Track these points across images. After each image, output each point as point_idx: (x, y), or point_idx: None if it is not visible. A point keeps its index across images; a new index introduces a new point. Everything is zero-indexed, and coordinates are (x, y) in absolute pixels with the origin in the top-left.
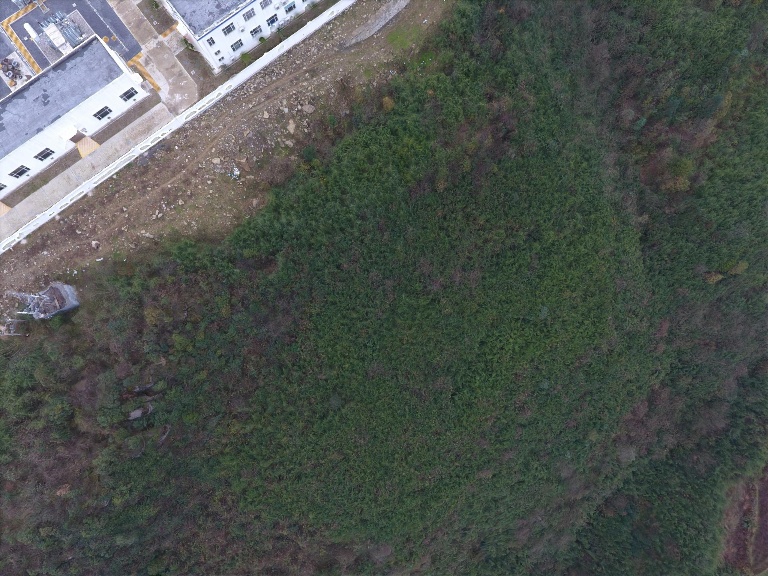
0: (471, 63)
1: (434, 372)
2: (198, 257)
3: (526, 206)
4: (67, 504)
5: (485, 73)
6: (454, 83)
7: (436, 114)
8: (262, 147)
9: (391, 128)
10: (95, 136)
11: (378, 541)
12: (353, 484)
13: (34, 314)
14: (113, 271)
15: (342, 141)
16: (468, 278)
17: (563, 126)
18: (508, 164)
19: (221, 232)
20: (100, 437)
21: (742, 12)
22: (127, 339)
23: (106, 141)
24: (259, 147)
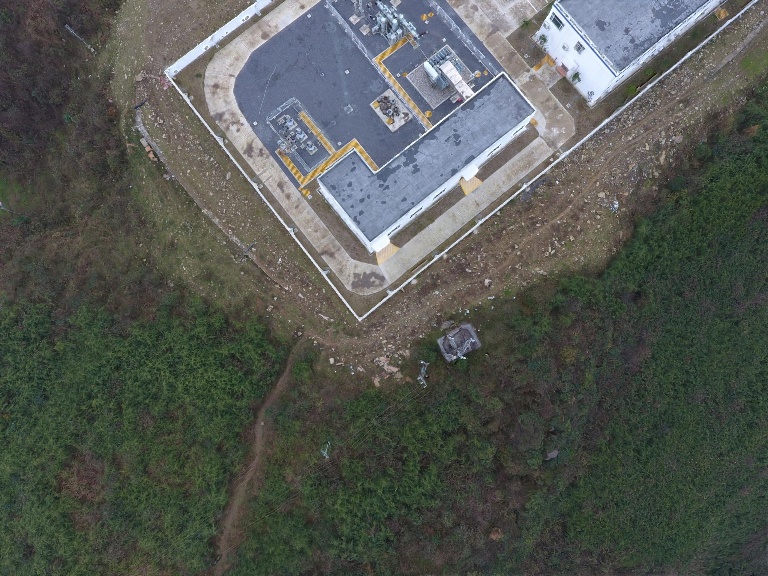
0: None
1: (729, 394)
2: (594, 293)
3: None
4: (497, 548)
5: None
6: None
7: None
8: (637, 179)
9: (756, 156)
10: None
11: (662, 564)
12: (657, 509)
13: (447, 356)
14: (518, 310)
15: (709, 170)
16: (765, 299)
17: None
18: None
19: (598, 266)
20: (524, 479)
21: None
22: (553, 380)
23: (488, 178)
24: (635, 179)
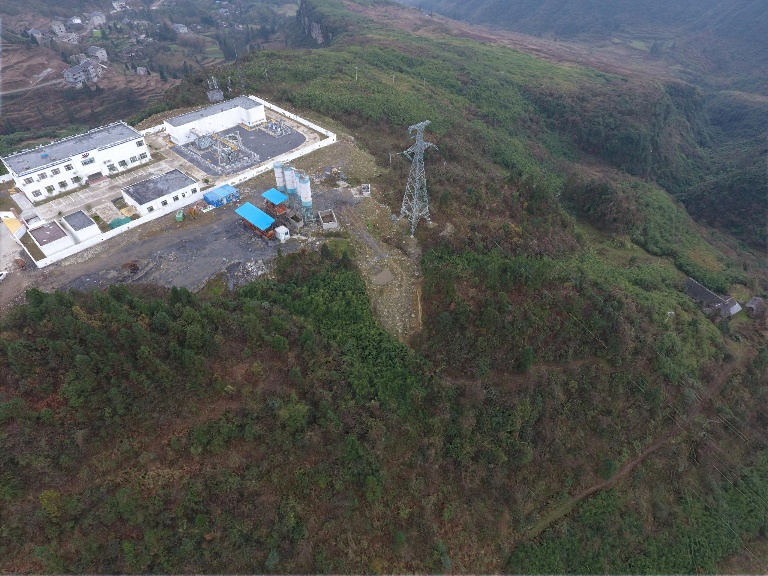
0: None
1: None
2: None
3: None
4: None
5: None
6: None
7: None
8: None
9: None
10: None
11: None
12: None
13: None
14: None
15: None
16: None
17: None
18: None
19: None
20: None
21: None
22: None
23: None
24: None
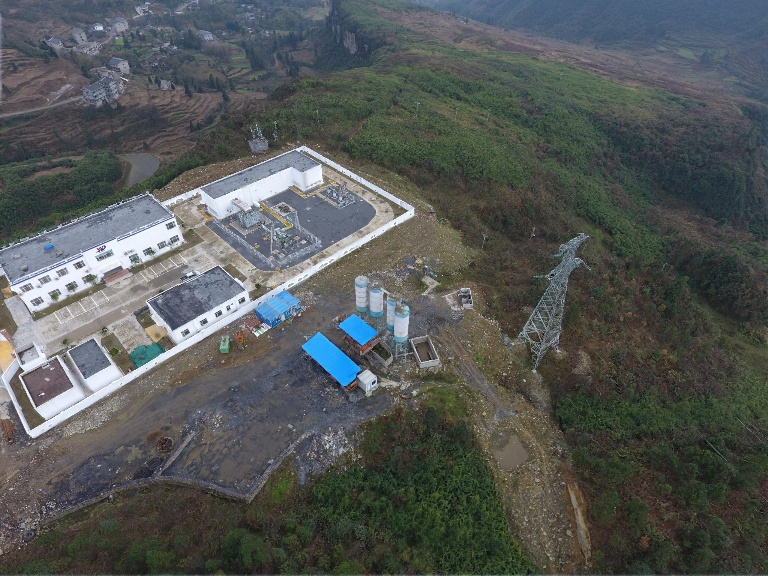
0: None
1: None
2: None
3: None
4: None
5: None
6: None
7: None
8: None
9: None
10: None
11: None
12: None
13: None
14: None
15: None
16: None
17: None
18: None
19: None
20: None
21: None
22: None
23: None
24: None
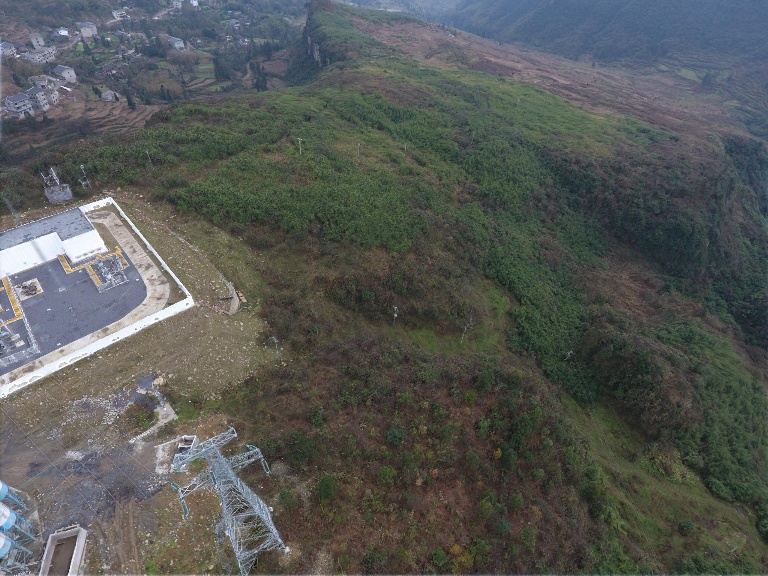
0: None
1: None
2: None
3: None
4: None
5: None
6: None
7: None
8: None
9: None
10: None
11: None
12: None
13: None
14: None
15: None
16: None
17: None
18: None
19: None
20: None
21: None
22: None
23: None
24: None
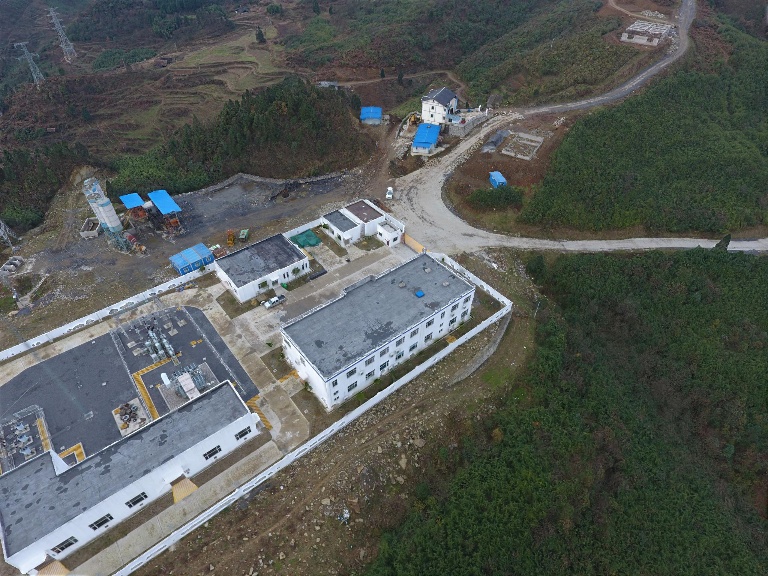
0: (564, 397)
1: None
2: None
3: (656, 549)
4: None
5: (576, 405)
6: (553, 415)
7: (546, 445)
8: (373, 484)
9: (506, 460)
10: (195, 478)
11: None
12: None
13: None
14: None
15: (457, 475)
16: None
17: (659, 455)
18: (626, 497)
19: None
20: None
21: (767, 352)
22: None
23: (206, 483)
24: (371, 484)
